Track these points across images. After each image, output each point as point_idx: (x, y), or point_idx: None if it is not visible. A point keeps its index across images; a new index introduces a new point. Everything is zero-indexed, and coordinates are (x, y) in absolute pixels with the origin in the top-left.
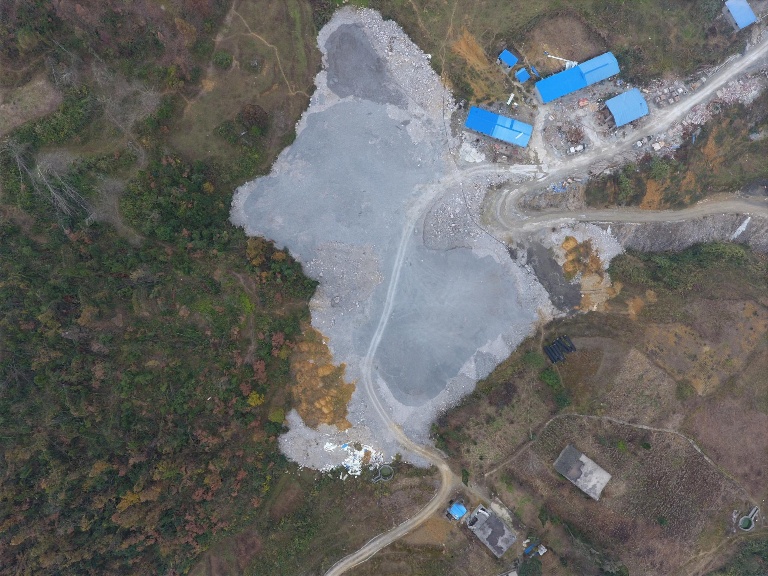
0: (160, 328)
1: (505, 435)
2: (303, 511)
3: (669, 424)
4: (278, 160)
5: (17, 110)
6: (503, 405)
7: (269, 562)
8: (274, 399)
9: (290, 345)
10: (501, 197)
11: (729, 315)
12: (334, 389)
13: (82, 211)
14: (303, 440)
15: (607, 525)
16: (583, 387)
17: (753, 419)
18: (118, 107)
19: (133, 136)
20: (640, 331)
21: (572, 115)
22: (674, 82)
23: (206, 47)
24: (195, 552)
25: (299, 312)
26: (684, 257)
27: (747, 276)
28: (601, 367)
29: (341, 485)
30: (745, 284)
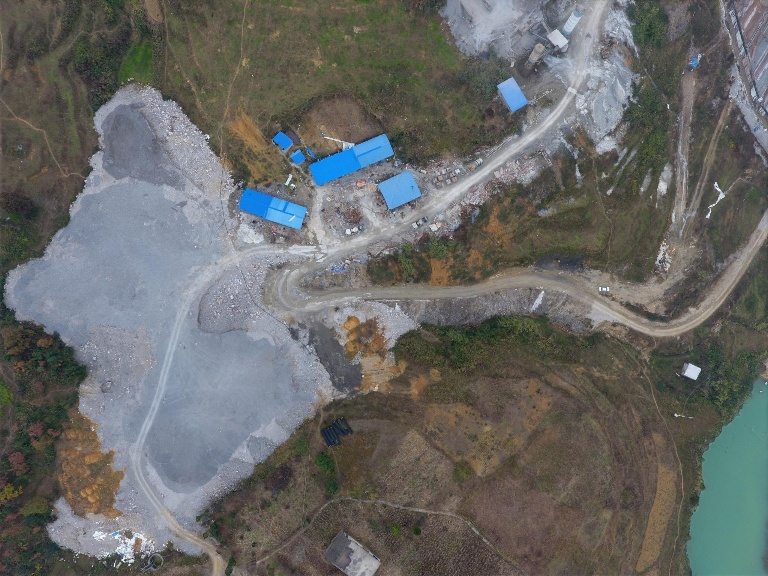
0: None
1: (280, 520)
2: None
3: (446, 507)
4: (52, 242)
5: None
6: (279, 489)
7: None
8: (41, 488)
9: (53, 434)
10: (282, 277)
11: (511, 394)
12: (101, 477)
13: None
14: (72, 529)
15: None
16: (357, 471)
17: (534, 499)
18: None
19: None
20: (420, 412)
21: (351, 196)
22: (453, 162)
23: None
24: None
25: (62, 400)
26: (481, 331)
27: (535, 352)
28: (377, 450)
29: (113, 574)
30: (531, 361)
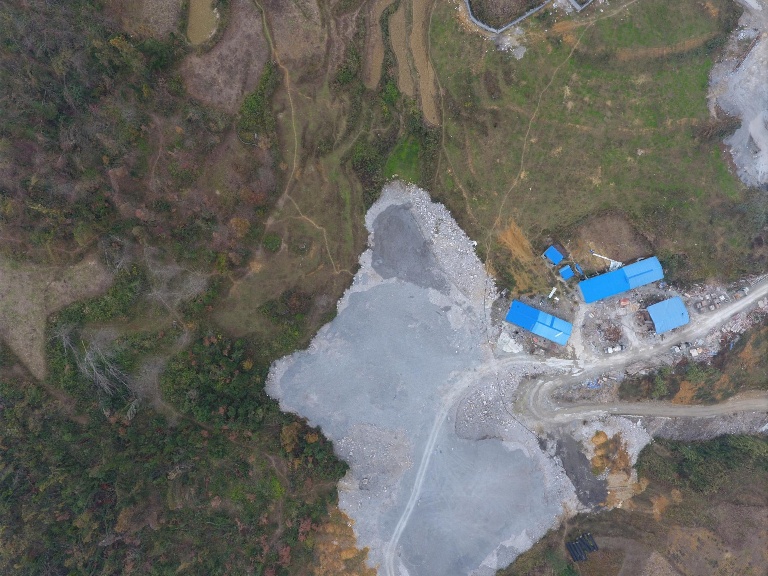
0: (191, 517)
1: None
2: None
3: None
4: (317, 336)
5: (67, 288)
6: None
7: None
8: None
9: (316, 529)
10: (535, 387)
11: (753, 522)
12: (356, 574)
13: (122, 387)
14: None
15: None
16: None
17: None
18: (166, 286)
19: (178, 315)
20: (663, 533)
21: (612, 313)
22: (716, 288)
23: (257, 232)
24: None
25: (328, 497)
26: (711, 448)
27: None
28: (622, 569)
29: None
30: None
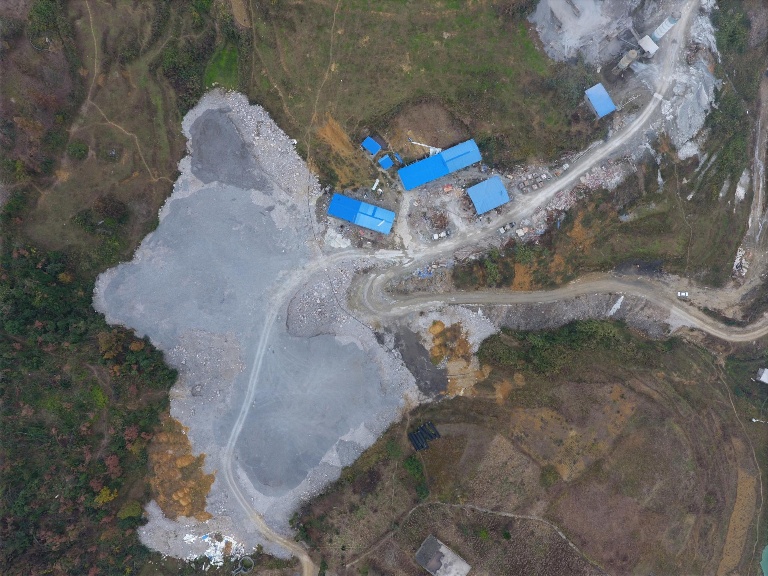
0: (1, 428)
1: (368, 524)
2: None
3: (533, 511)
4: (141, 246)
5: None
6: (367, 493)
7: None
8: (132, 491)
9: (146, 437)
10: (368, 282)
11: (596, 399)
12: (192, 481)
13: None
14: (163, 531)
15: None
16: (446, 475)
17: (619, 504)
18: None
19: None
20: (506, 416)
21: (437, 201)
22: (538, 168)
23: (59, 138)
24: None
25: (155, 404)
26: (560, 335)
27: (617, 357)
28: (465, 454)
29: None
30: (614, 366)
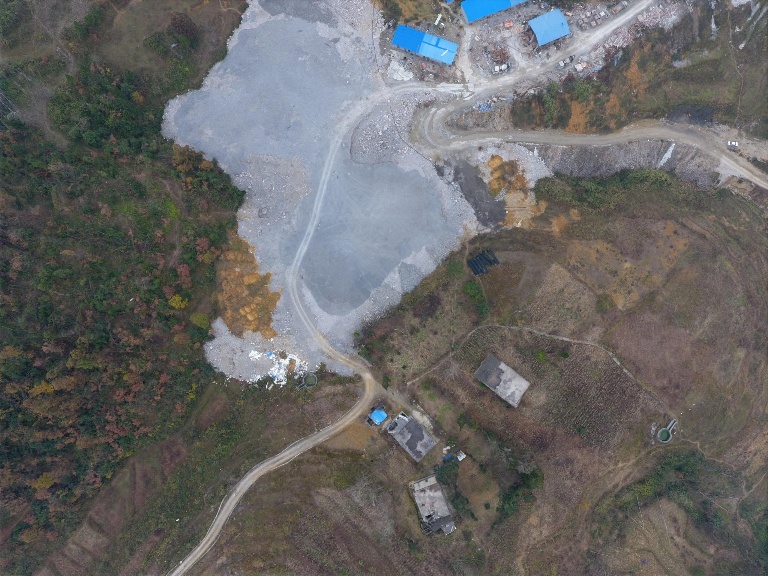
0: (81, 225)
1: (428, 346)
2: (229, 420)
3: (589, 336)
4: (209, 75)
5: None
6: (427, 316)
7: (193, 468)
8: (200, 307)
9: (215, 252)
10: (429, 116)
11: (650, 233)
12: (259, 297)
13: None
14: (229, 348)
15: (527, 433)
16: (505, 299)
17: (672, 334)
18: (47, 13)
19: (62, 42)
20: (562, 247)
21: (498, 36)
22: (597, 6)
23: None
24: (117, 455)
25: (225, 219)
26: None
27: (669, 198)
28: (523, 280)
29: (266, 394)
30: (667, 205)
